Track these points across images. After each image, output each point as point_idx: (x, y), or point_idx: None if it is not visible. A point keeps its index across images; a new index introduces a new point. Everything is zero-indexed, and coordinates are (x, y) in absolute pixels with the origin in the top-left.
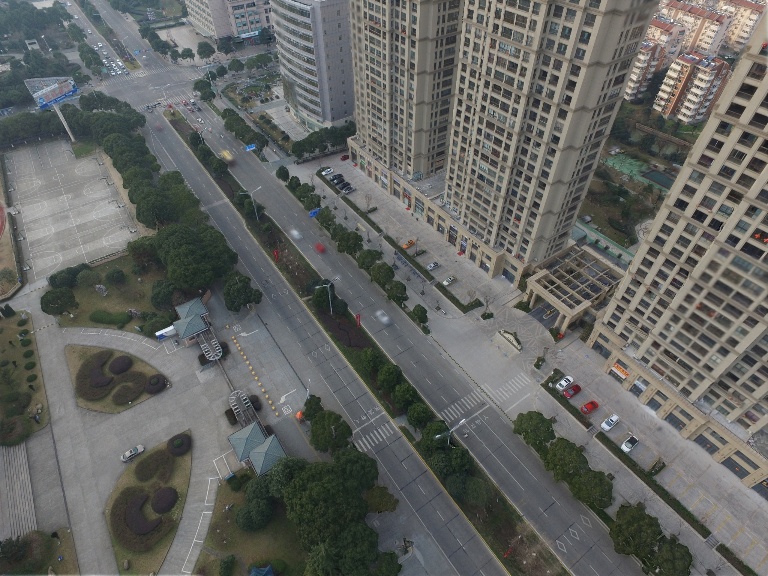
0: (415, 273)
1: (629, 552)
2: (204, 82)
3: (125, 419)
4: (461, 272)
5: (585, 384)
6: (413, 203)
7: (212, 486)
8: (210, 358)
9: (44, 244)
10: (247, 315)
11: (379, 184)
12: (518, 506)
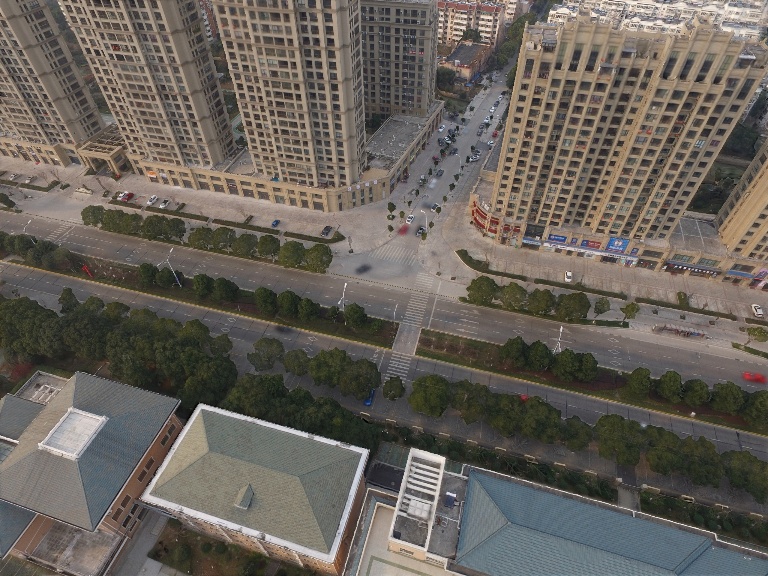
0: (1, 187)
1: (151, 235)
2: None
3: None
4: None
5: (137, 192)
6: None
7: None
8: None
9: None
10: None
11: None
12: (100, 257)
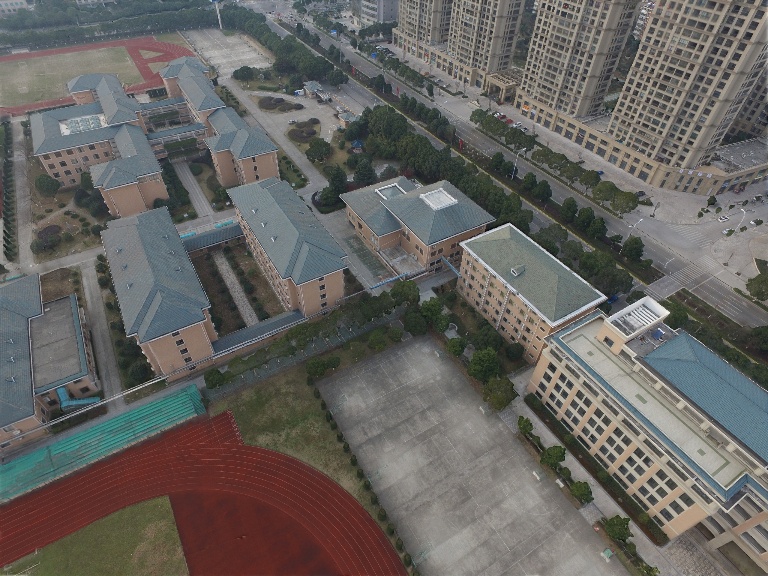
0: None
1: (511, 140)
2: (300, 3)
3: (286, 115)
4: (453, 84)
5: (509, 116)
6: (430, 57)
7: (331, 131)
8: (325, 97)
9: (222, 65)
10: (339, 92)
11: (410, 53)
12: None
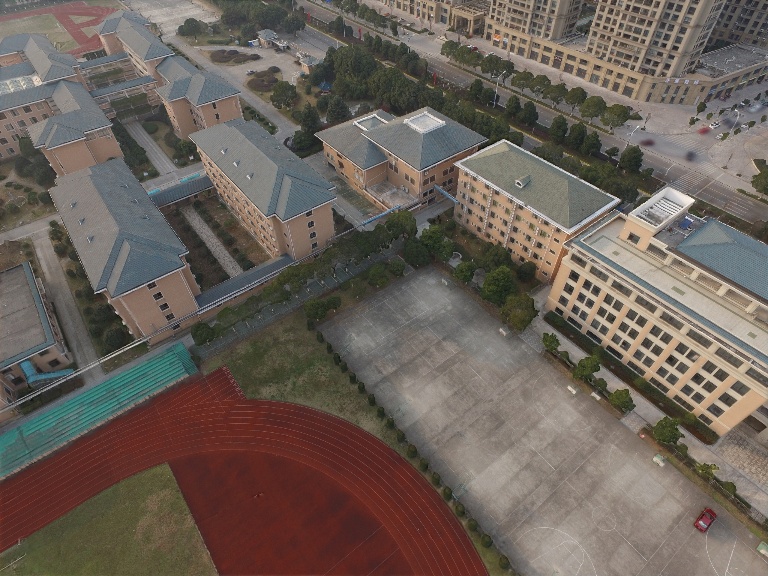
0: None
1: (487, 68)
2: None
3: (242, 66)
4: (417, 22)
5: (480, 48)
6: None
7: (294, 78)
8: (282, 45)
9: (164, 23)
10: (297, 39)
11: None
12: None
